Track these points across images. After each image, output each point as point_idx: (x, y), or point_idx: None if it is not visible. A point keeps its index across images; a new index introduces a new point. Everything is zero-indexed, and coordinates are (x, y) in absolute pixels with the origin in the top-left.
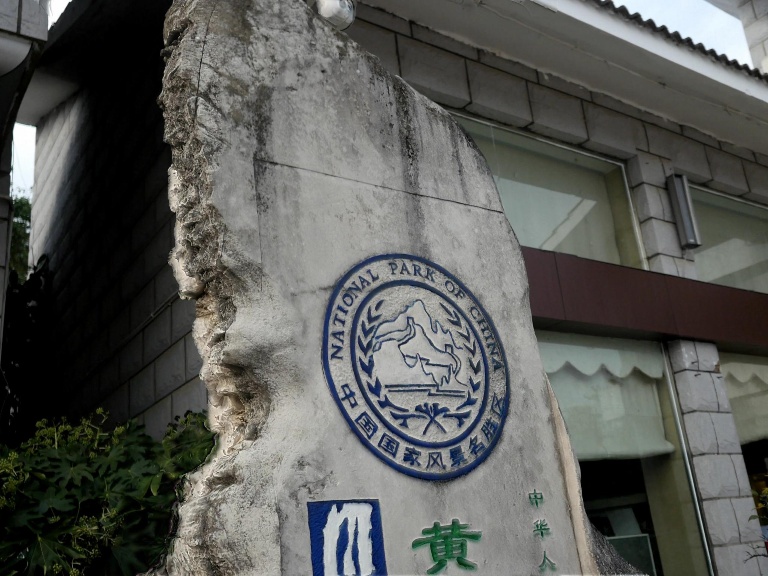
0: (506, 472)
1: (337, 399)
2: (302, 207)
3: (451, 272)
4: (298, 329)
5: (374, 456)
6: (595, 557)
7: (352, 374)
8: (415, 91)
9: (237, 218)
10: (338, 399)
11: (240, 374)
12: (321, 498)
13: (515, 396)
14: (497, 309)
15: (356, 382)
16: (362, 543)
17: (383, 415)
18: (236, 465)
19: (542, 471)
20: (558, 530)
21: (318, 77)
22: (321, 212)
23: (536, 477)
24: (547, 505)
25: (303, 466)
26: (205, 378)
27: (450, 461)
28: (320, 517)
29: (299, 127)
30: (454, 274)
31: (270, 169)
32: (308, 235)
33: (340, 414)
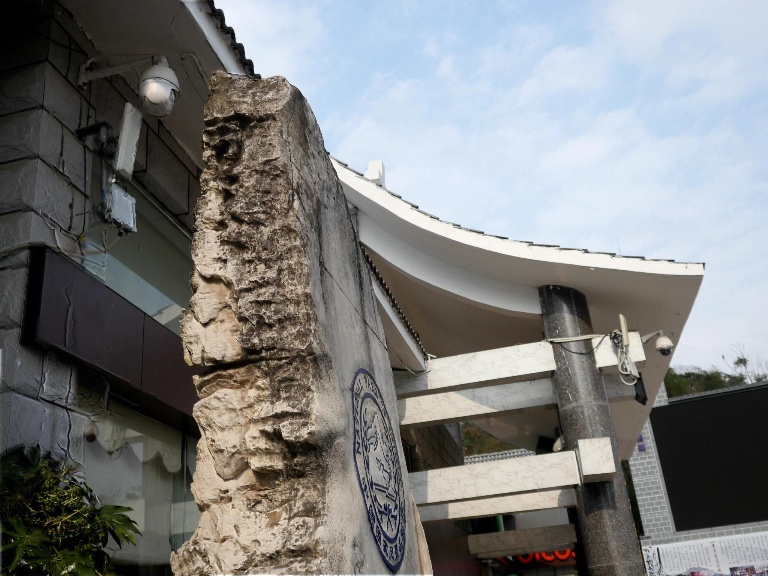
0: (409, 570)
1: (362, 490)
2: (337, 313)
3: (381, 394)
4: (346, 422)
5: (376, 544)
6: None
7: (364, 469)
8: None
9: None
10: None
11: (306, 454)
12: None
13: (406, 507)
14: (395, 431)
15: (366, 477)
16: None
17: None
18: (320, 539)
19: (417, 572)
20: None
21: (333, 202)
22: (342, 321)
23: None
24: None
25: (355, 547)
26: (239, 450)
27: (395, 556)
28: None
29: (330, 242)
30: (382, 396)
31: (325, 273)
32: (341, 339)
33: (364, 503)
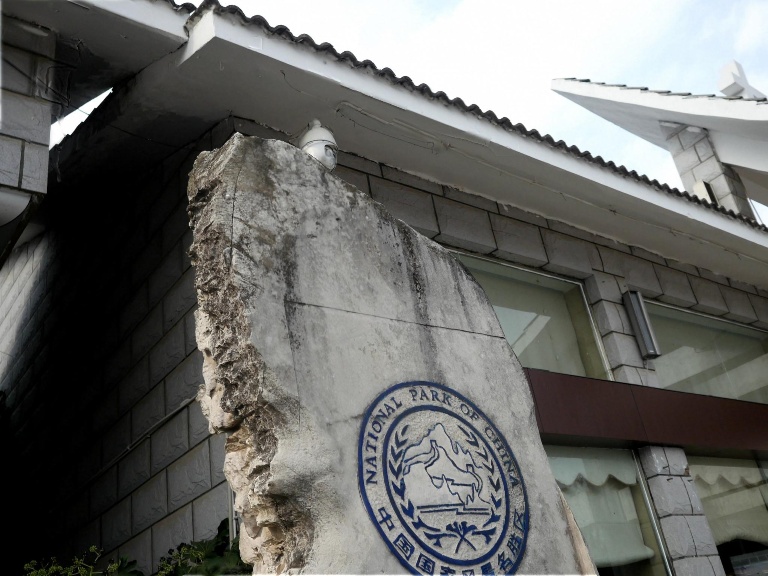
0: None
1: (376, 522)
2: (329, 342)
3: (464, 396)
4: (335, 457)
5: None
6: None
7: (387, 497)
8: (416, 232)
9: (274, 356)
10: (376, 522)
11: (284, 503)
12: None
13: (534, 511)
14: (508, 428)
15: (391, 505)
16: None
17: (418, 536)
18: None
19: None
20: None
21: (334, 224)
22: (346, 346)
23: None
24: None
25: None
26: (245, 510)
27: None
28: None
29: (321, 270)
30: (467, 397)
31: (299, 309)
32: (337, 368)
33: (379, 537)
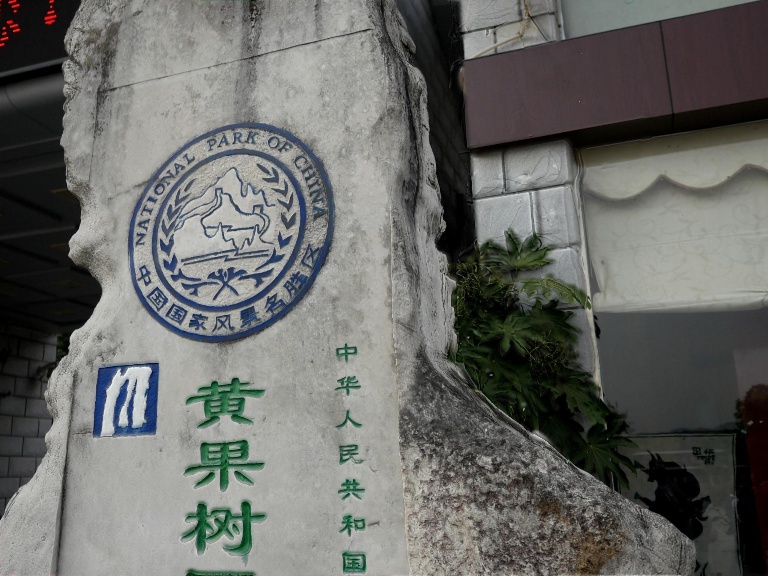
0: (308, 328)
1: (134, 280)
2: (131, 118)
3: (279, 126)
4: (110, 227)
5: (161, 326)
6: (400, 418)
7: (151, 256)
8: None
9: (77, 149)
10: (135, 280)
11: None
12: (109, 364)
13: (338, 243)
14: (333, 149)
15: (153, 262)
16: (137, 401)
17: (174, 288)
18: None
19: (362, 322)
20: (374, 387)
21: None
22: (148, 116)
23: (351, 330)
24: (362, 360)
25: (101, 340)
26: None
27: (240, 323)
28: (107, 380)
29: (140, 45)
30: (283, 127)
31: (110, 96)
32: (132, 142)
33: (135, 293)
